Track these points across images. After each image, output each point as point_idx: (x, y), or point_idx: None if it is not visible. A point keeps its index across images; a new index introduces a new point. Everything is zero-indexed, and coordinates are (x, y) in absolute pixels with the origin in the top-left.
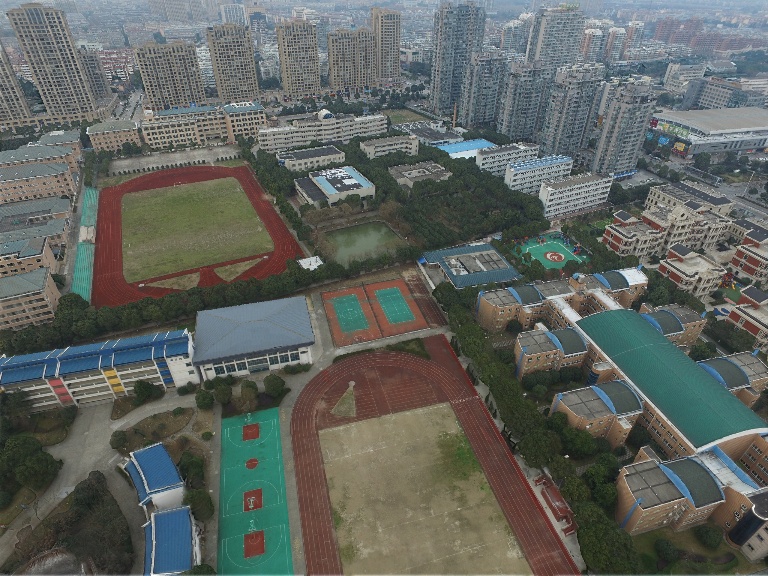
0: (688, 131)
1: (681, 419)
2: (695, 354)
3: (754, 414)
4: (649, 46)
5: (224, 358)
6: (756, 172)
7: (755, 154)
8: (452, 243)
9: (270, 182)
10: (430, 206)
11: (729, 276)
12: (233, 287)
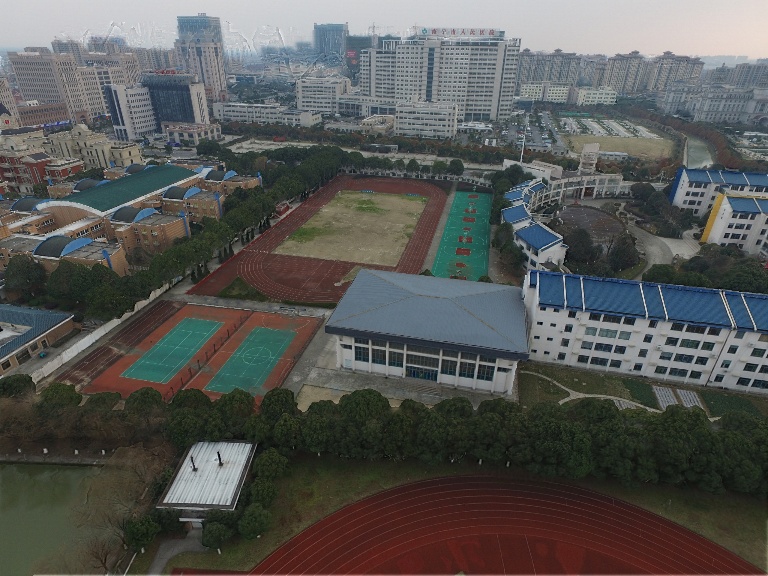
0: None
1: (180, 176)
2: None
3: None
4: None
5: None
6: None
7: None
8: None
9: None
10: None
11: None
12: None
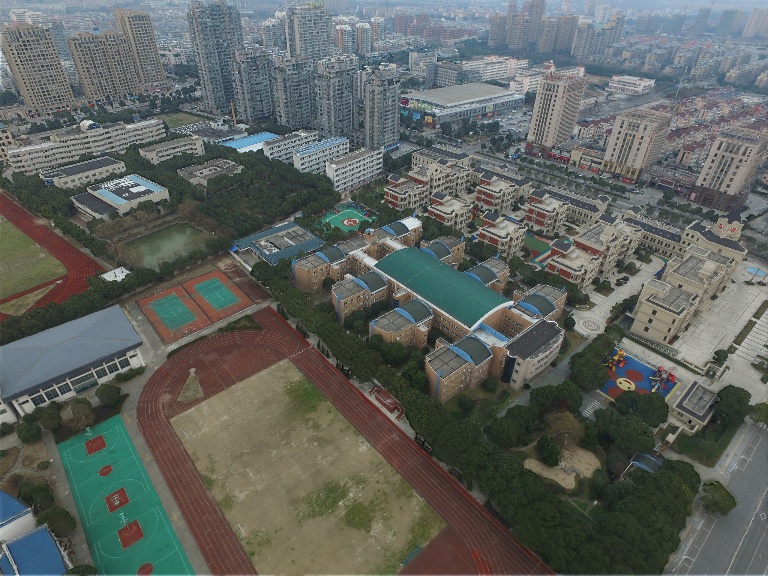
0: (431, 106)
1: (457, 312)
2: (462, 268)
3: (501, 296)
4: (392, 38)
5: (41, 384)
6: (484, 132)
7: (481, 119)
8: (259, 228)
9: (40, 205)
10: (229, 199)
11: (477, 210)
12: (28, 317)
